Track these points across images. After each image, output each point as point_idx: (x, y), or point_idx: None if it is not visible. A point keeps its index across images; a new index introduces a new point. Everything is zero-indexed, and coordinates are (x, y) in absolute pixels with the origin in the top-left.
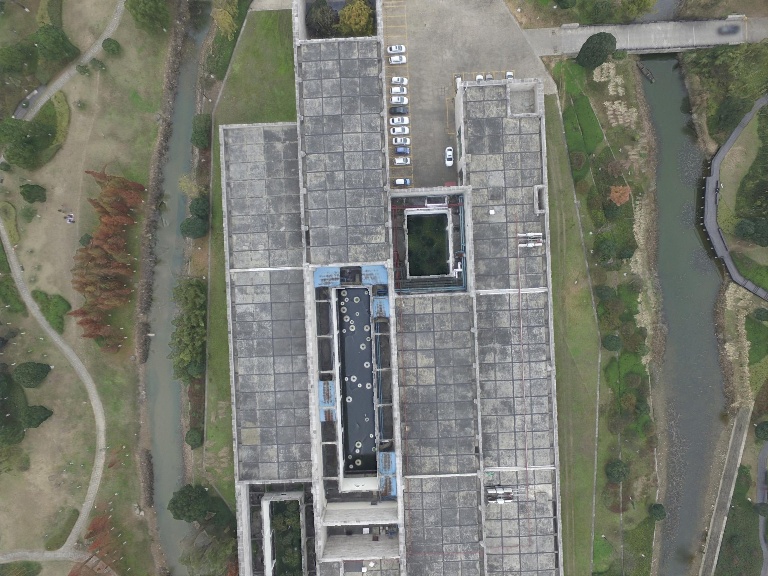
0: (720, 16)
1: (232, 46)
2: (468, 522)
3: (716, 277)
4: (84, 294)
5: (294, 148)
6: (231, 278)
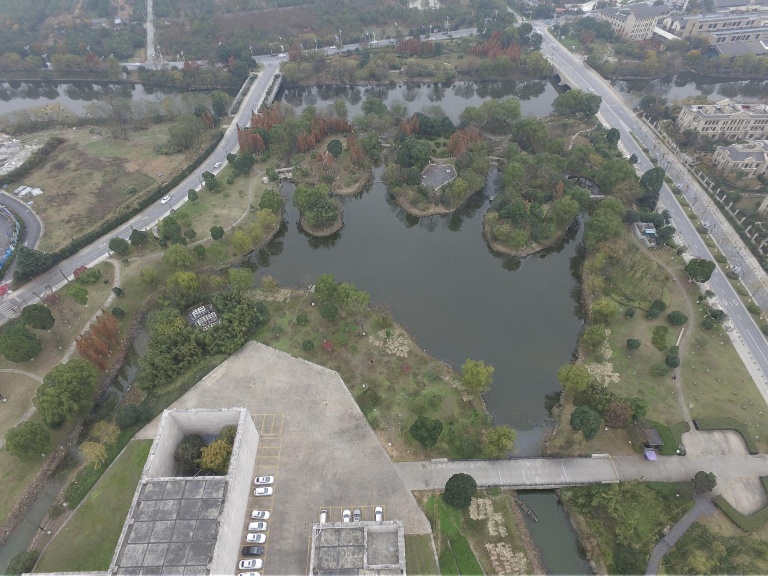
0: (585, 454)
1: (100, 473)
2: None
3: None
4: None
5: None
6: None
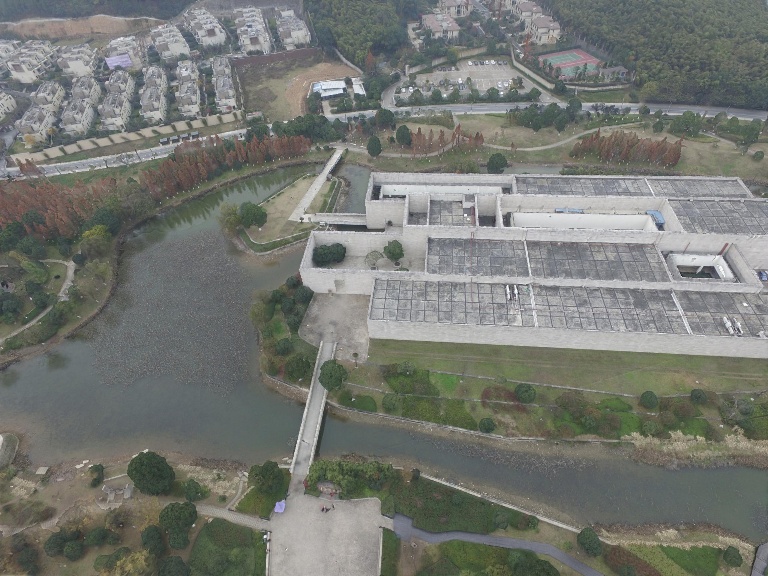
0: None
1: None
2: (494, 270)
3: (752, 535)
4: None
5: None
6: None
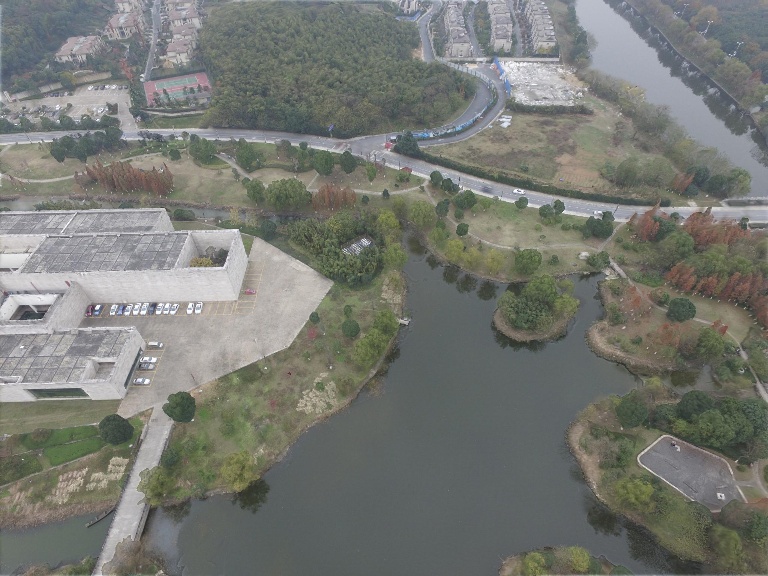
0: None
1: None
2: None
3: None
4: None
5: None
6: None
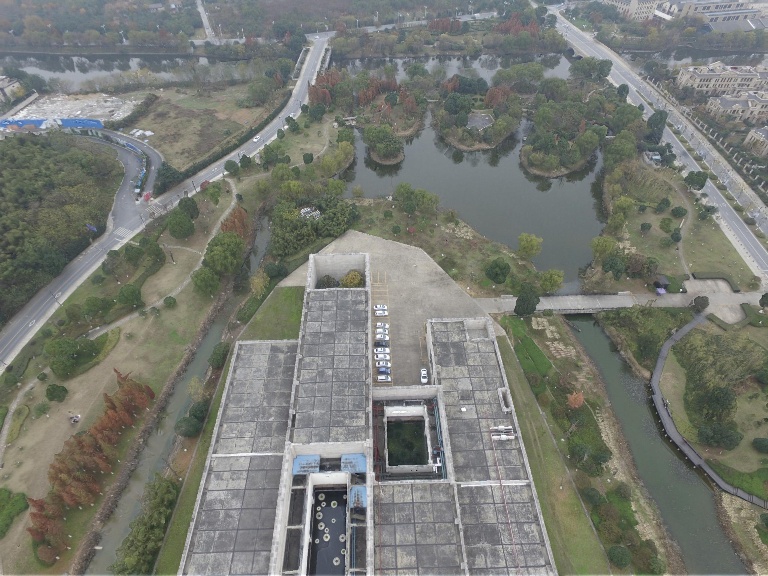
0: (613, 293)
1: (259, 305)
2: None
3: (705, 489)
4: (55, 482)
5: (293, 358)
6: (211, 464)
